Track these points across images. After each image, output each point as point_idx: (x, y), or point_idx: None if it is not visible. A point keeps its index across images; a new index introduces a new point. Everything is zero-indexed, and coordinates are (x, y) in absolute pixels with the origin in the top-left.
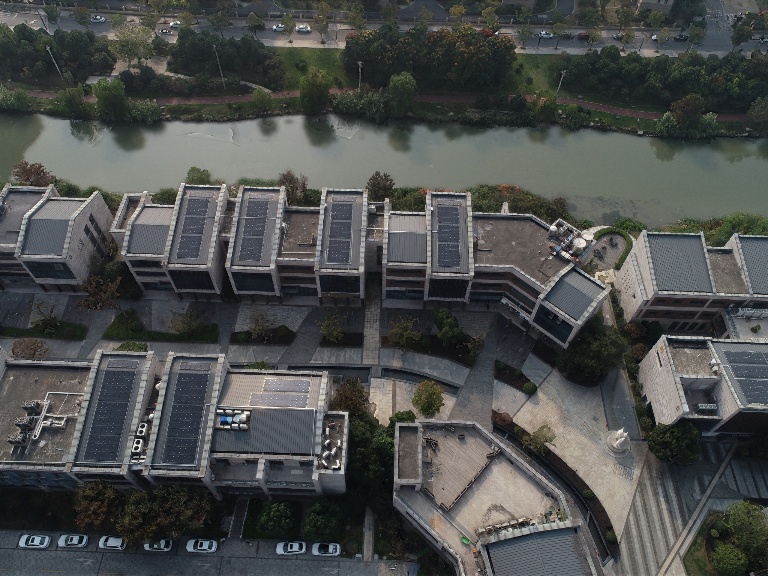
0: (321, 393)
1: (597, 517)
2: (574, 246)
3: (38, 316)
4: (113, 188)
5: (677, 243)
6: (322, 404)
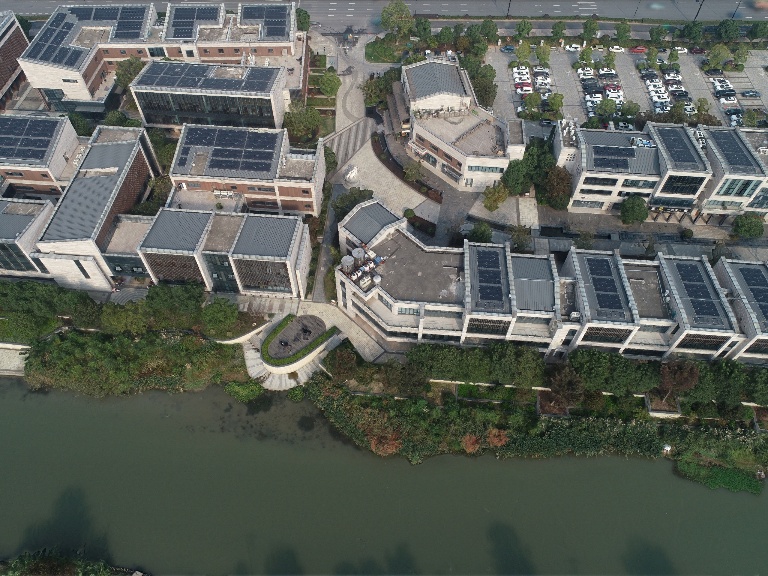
0: (585, 154)
1: (381, 147)
2: None
3: None
4: None
5: (259, 251)
6: (583, 146)
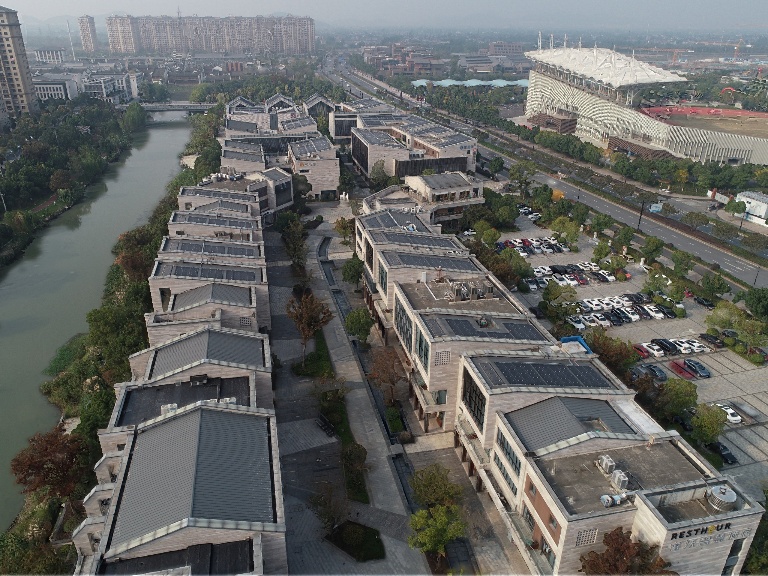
0: (375, 212)
1: None
2: (232, 170)
3: (317, 438)
4: (13, 497)
5: None
6: (383, 208)
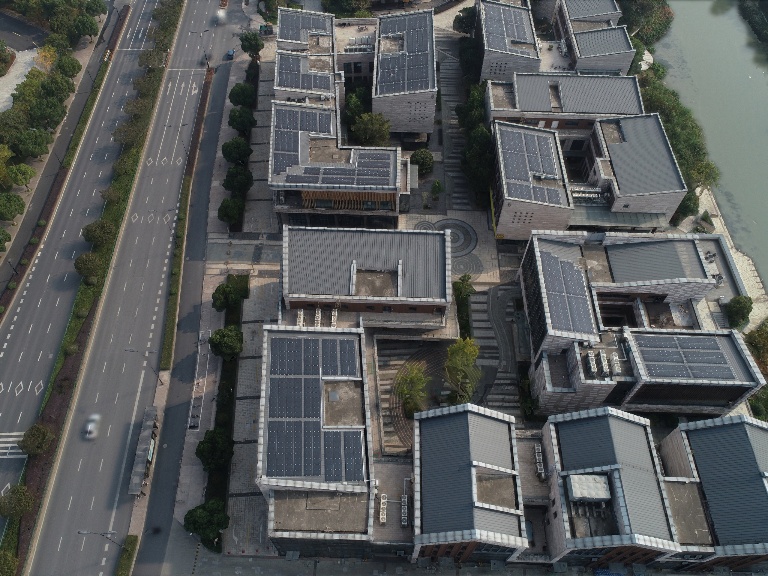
0: None
1: None
2: None
3: None
4: None
5: (607, 4)
6: None
